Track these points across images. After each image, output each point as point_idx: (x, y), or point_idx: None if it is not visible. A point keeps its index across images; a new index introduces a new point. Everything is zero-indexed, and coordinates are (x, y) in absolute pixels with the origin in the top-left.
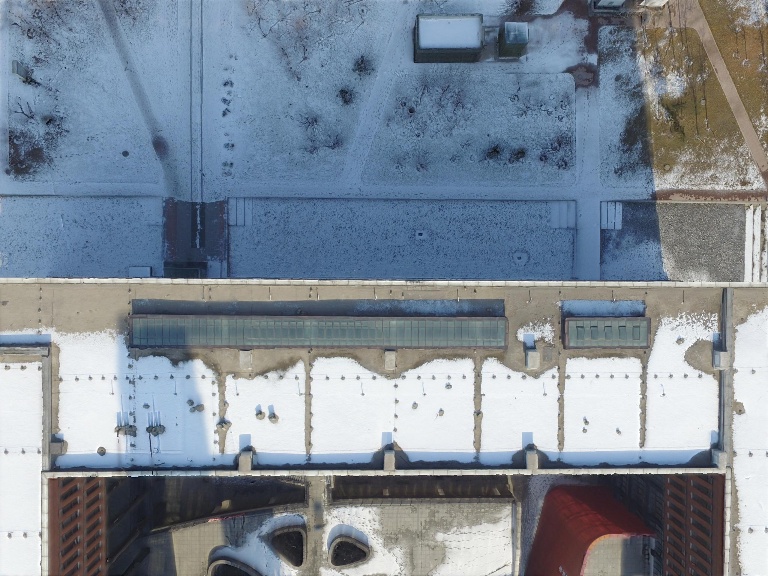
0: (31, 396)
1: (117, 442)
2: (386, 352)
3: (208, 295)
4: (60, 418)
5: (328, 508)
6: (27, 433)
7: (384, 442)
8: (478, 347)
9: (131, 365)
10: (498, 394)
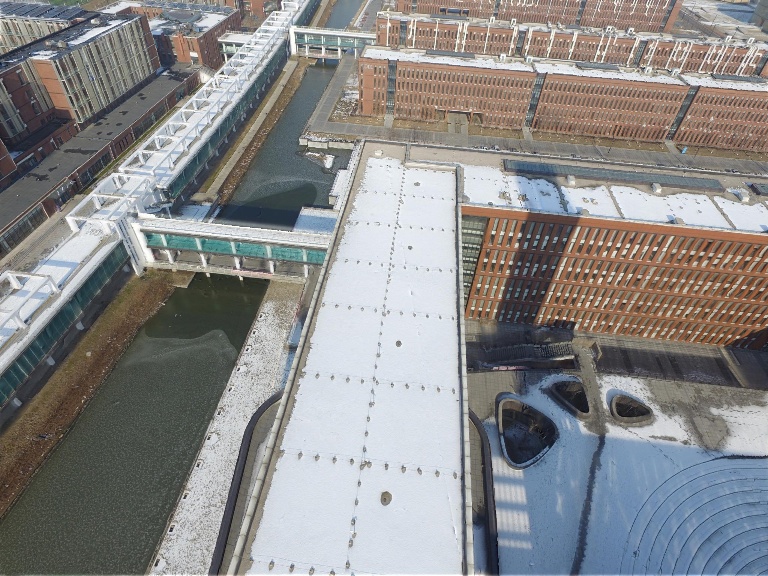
0: (448, 181)
1: (500, 201)
2: (654, 183)
3: (543, 161)
4: (465, 190)
5: (599, 375)
6: (445, 193)
7: (670, 219)
8: (707, 187)
9: (505, 177)
10: (731, 209)
